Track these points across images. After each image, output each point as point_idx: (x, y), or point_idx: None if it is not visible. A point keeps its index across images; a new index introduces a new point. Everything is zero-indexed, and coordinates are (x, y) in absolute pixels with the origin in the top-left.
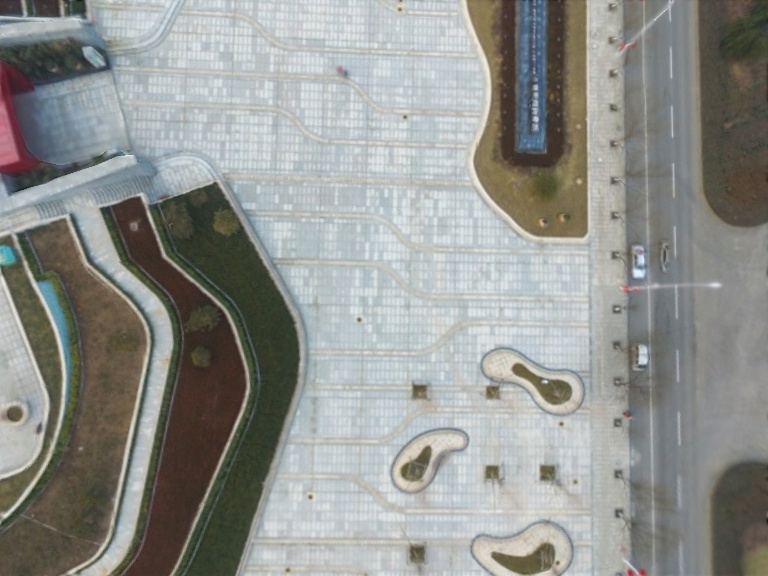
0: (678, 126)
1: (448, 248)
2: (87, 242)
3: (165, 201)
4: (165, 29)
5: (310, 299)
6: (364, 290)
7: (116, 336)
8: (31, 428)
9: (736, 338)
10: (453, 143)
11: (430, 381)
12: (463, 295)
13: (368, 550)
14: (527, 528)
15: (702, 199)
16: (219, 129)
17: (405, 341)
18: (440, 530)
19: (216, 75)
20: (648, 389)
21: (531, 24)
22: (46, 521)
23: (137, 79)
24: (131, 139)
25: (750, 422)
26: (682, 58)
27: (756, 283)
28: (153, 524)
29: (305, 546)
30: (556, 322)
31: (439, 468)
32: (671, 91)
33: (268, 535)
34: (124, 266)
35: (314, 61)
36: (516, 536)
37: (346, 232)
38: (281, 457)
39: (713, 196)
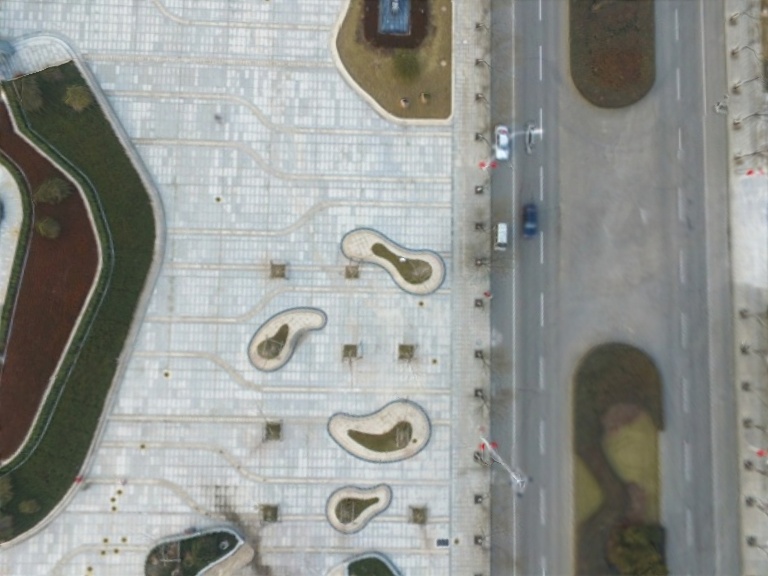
0: (546, 9)
1: (309, 129)
2: None
3: (20, 78)
4: None
5: (169, 179)
6: (223, 170)
7: None
8: None
9: (602, 220)
10: (316, 25)
11: (289, 261)
12: (324, 176)
13: (224, 427)
14: (385, 407)
15: (569, 81)
16: (78, 10)
17: (264, 221)
18: (297, 408)
19: None
20: (511, 270)
21: None
22: None
23: None
24: None
25: (615, 304)
26: None
27: (624, 165)
28: (2, 395)
29: (160, 423)
30: (418, 203)
31: (297, 347)
32: None
33: (123, 412)
34: None
35: None
36: (373, 414)
37: (206, 113)
38: (137, 335)
39: (579, 77)
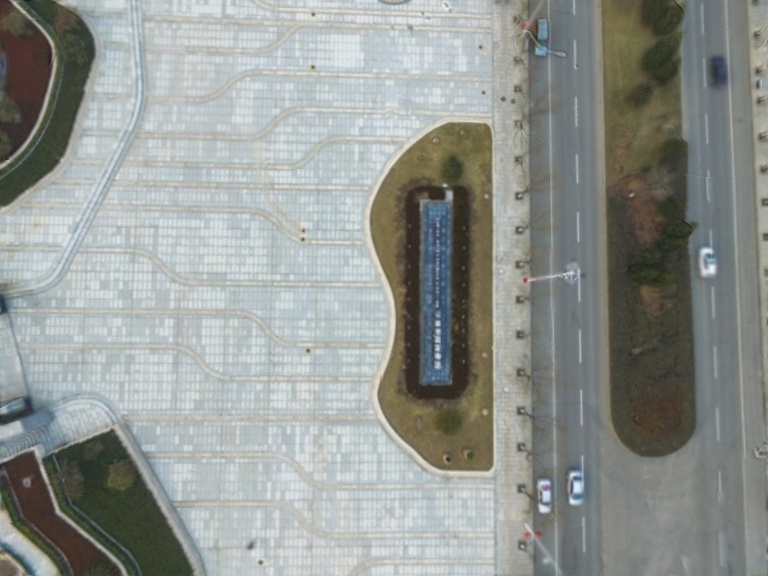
0: (586, 351)
1: (352, 485)
2: None
3: (60, 452)
4: (63, 268)
5: (211, 542)
6: (266, 531)
7: None
8: None
9: (644, 571)
10: (357, 376)
11: None
12: (367, 534)
13: None
14: None
15: (610, 428)
16: (118, 369)
17: None
18: None
19: (115, 314)
20: None
21: (434, 255)
22: None
23: (34, 321)
24: (28, 383)
25: None
26: (590, 281)
27: (665, 513)
28: None
29: None
30: (461, 559)
31: None
32: (579, 315)
33: None
34: (15, 527)
35: (215, 296)
36: None
37: (248, 472)
38: None
39: (620, 426)
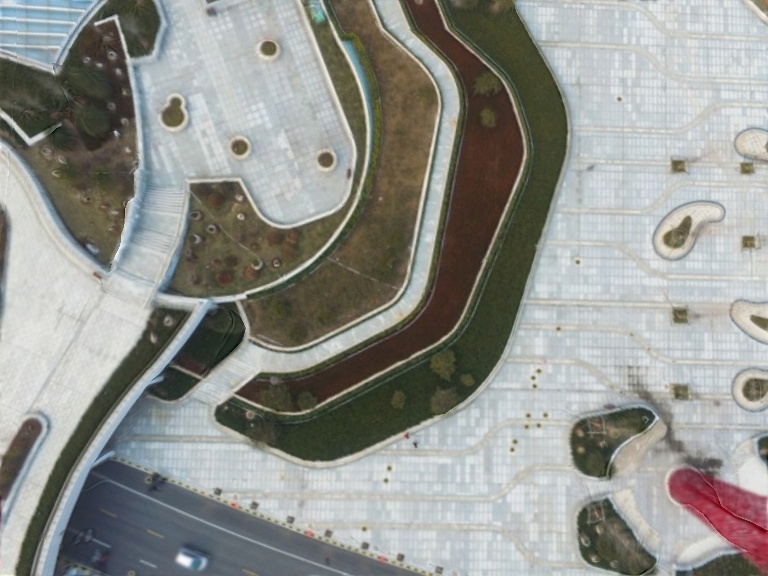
0: None
1: (701, 35)
2: (380, 11)
3: None
4: None
5: (573, 79)
6: (623, 72)
7: (410, 97)
8: (340, 174)
9: None
10: None
11: (687, 157)
12: (716, 78)
13: (633, 312)
14: None
15: None
16: None
17: (663, 120)
18: (700, 295)
19: None
20: None
21: None
22: (349, 265)
23: None
24: None
25: None
26: None
27: None
28: (442, 275)
29: (574, 307)
30: None
31: (698, 238)
32: None
33: (539, 296)
34: (414, 34)
35: None
36: None
37: (605, 18)
38: (549, 225)
39: None
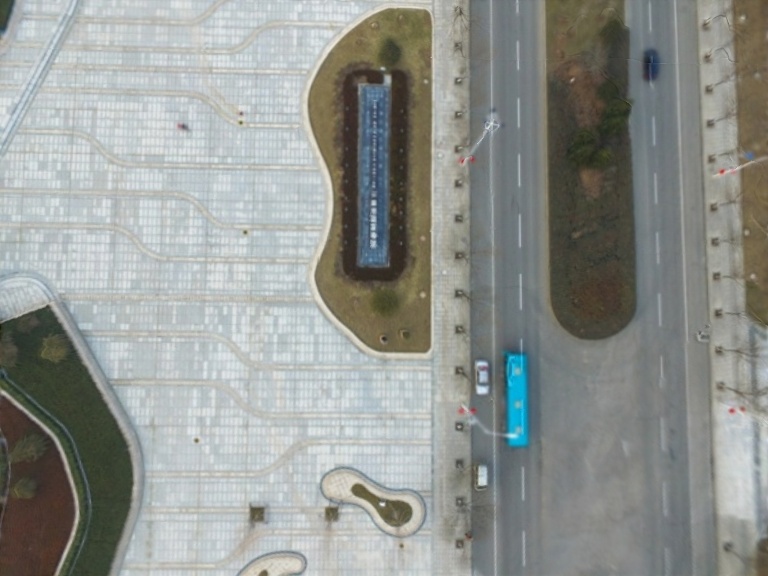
0: (526, 235)
1: (288, 365)
2: None
3: None
4: (2, 149)
5: (147, 420)
6: (202, 410)
7: None
8: None
9: (584, 454)
10: (294, 258)
11: (268, 503)
12: (303, 414)
13: None
14: None
15: (549, 311)
16: (56, 249)
17: (243, 462)
18: None
19: (53, 194)
20: (492, 508)
21: (371, 137)
22: None
23: None
24: None
25: (598, 541)
26: (530, 165)
27: (605, 396)
28: None
29: None
30: (398, 440)
31: None
32: (519, 199)
33: None
34: None
35: (153, 177)
36: None
37: (184, 351)
38: None
39: (559, 308)
